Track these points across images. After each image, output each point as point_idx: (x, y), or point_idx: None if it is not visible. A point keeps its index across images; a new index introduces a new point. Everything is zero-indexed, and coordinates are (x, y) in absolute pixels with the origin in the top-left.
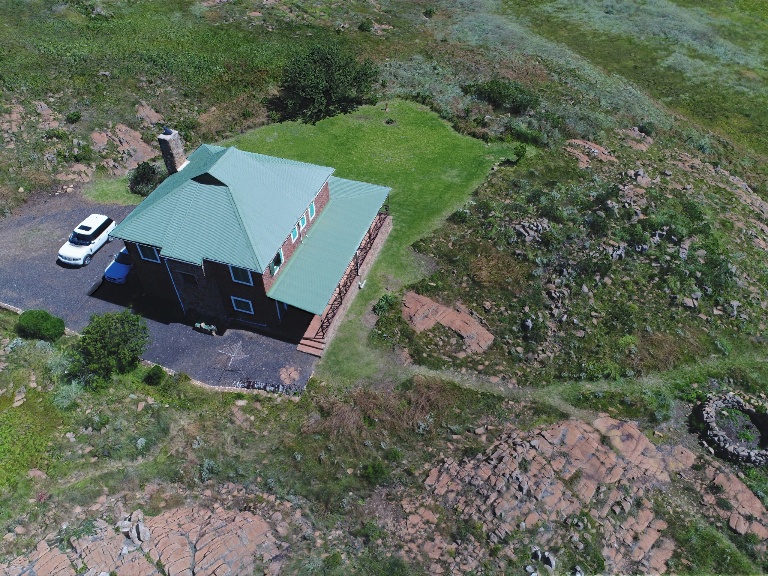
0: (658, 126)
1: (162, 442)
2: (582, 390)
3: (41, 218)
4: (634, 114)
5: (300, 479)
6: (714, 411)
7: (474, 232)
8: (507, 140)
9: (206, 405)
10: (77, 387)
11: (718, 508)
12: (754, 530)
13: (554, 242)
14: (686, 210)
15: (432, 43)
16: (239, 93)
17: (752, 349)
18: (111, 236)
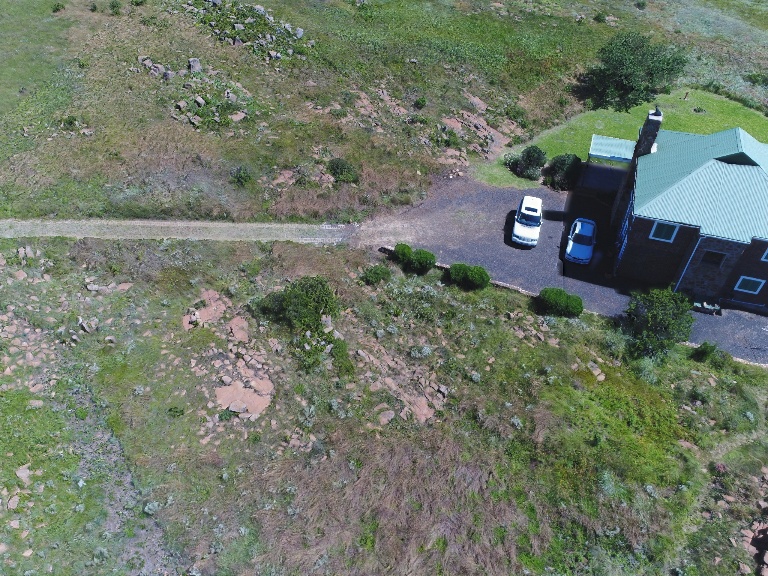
0: None
1: (760, 416)
2: None
3: (456, 200)
4: None
5: None
6: None
7: None
8: None
9: (767, 382)
10: None
11: None
12: None
13: None
14: None
15: (669, 34)
16: (534, 81)
17: None
18: (637, 215)
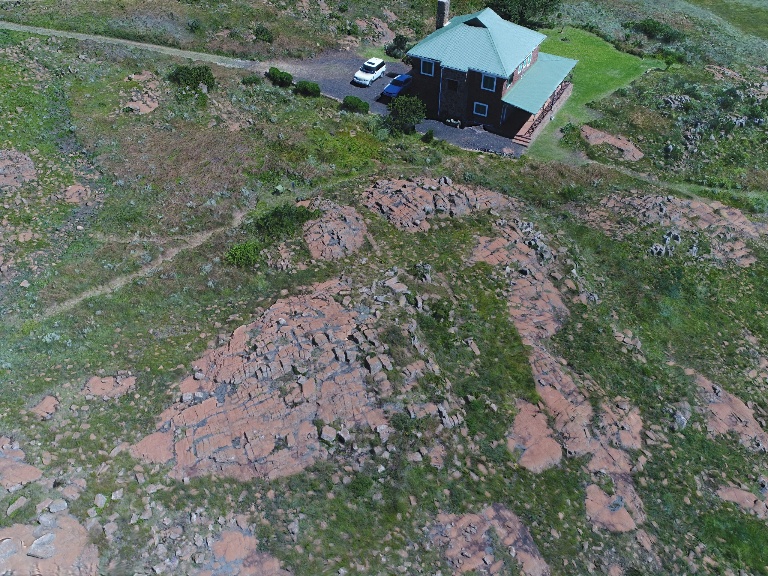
0: None
1: (438, 164)
2: None
3: (334, 61)
4: (765, 60)
5: (522, 191)
6: None
7: (632, 101)
8: (658, 58)
9: None
10: (386, 132)
11: None
12: None
13: (693, 109)
14: None
15: None
16: None
17: None
18: (408, 53)
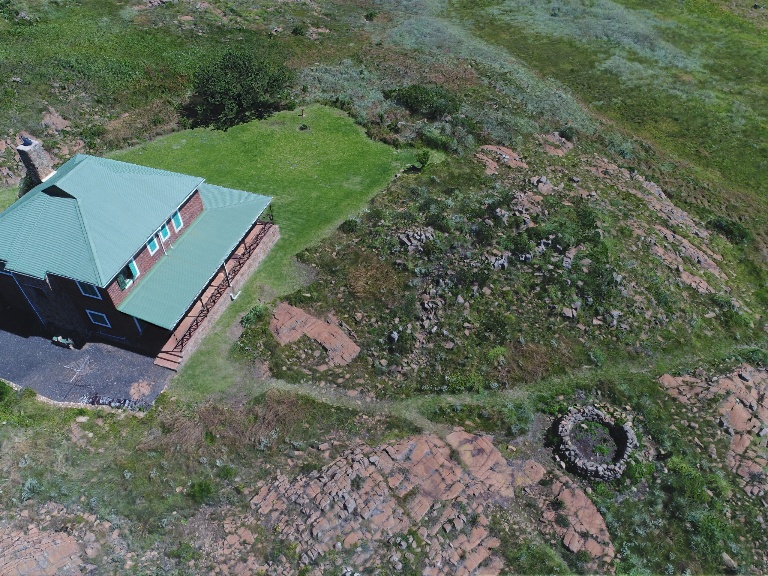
0: (581, 131)
1: None
2: (442, 403)
3: None
4: (559, 119)
5: (125, 498)
6: (573, 424)
7: (360, 241)
8: (417, 146)
9: (46, 421)
10: None
11: (556, 525)
12: (588, 547)
13: (435, 252)
14: (580, 218)
15: (366, 47)
16: (155, 99)
17: (628, 360)
18: None
